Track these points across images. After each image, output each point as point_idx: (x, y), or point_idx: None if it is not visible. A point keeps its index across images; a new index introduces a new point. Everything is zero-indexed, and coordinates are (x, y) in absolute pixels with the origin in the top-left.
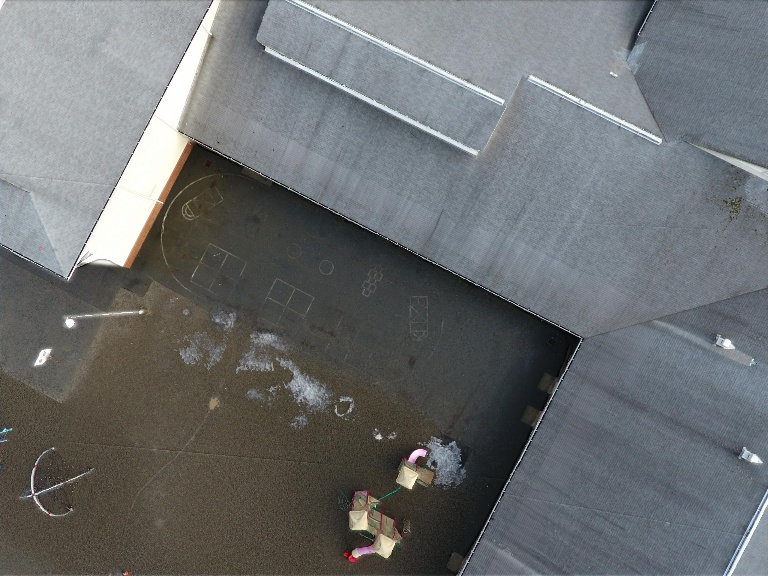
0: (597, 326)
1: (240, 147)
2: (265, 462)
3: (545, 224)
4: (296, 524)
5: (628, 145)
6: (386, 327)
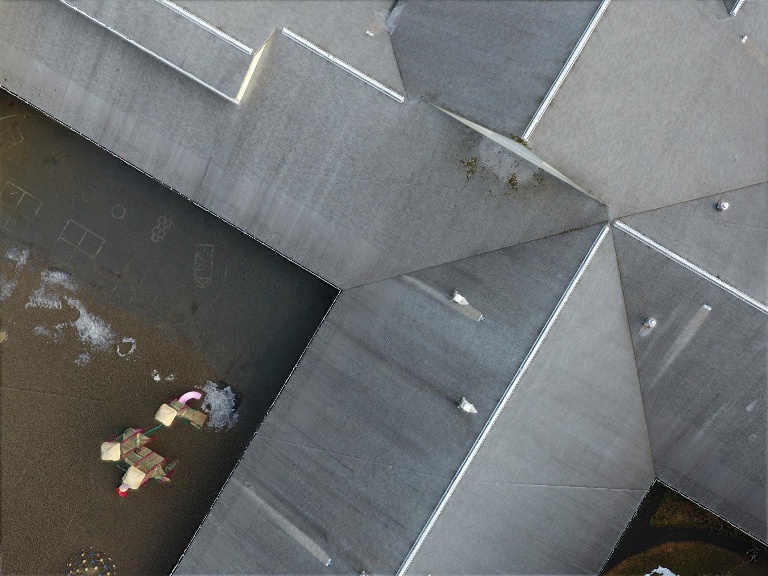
0: (353, 279)
1: (25, 85)
2: (47, 396)
3: (303, 176)
4: (72, 458)
5: (374, 102)
6: (172, 273)
